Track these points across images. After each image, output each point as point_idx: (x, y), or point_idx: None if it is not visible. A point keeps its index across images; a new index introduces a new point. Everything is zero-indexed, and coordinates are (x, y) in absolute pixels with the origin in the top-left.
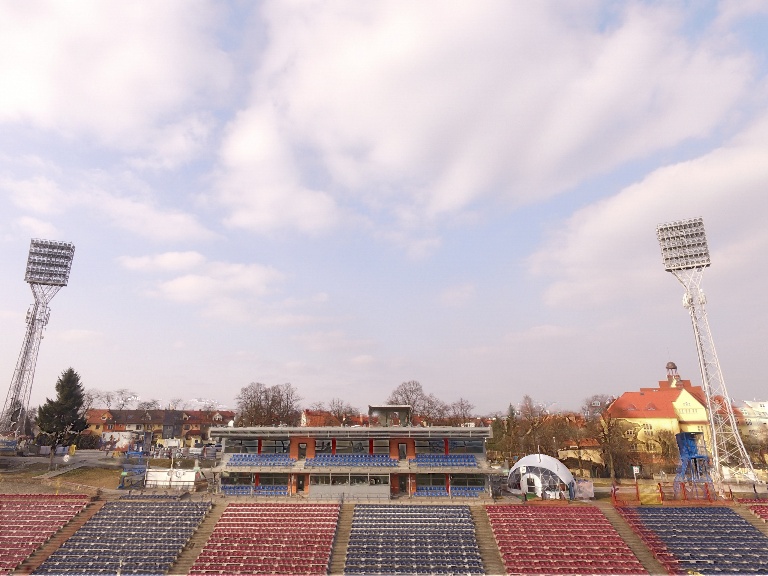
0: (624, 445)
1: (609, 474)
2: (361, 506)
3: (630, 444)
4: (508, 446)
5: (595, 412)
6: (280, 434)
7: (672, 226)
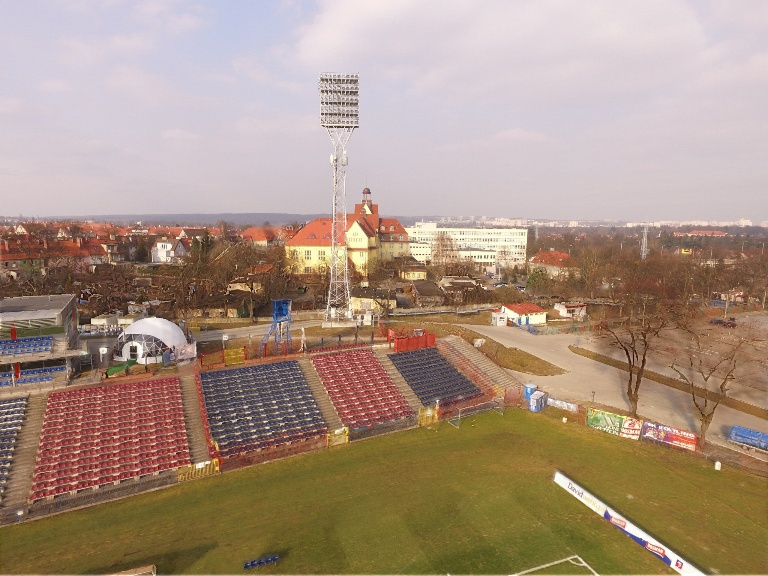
0: (277, 282)
1: (249, 314)
2: None
3: (283, 281)
4: (194, 272)
5: (287, 236)
6: None
7: (332, 78)
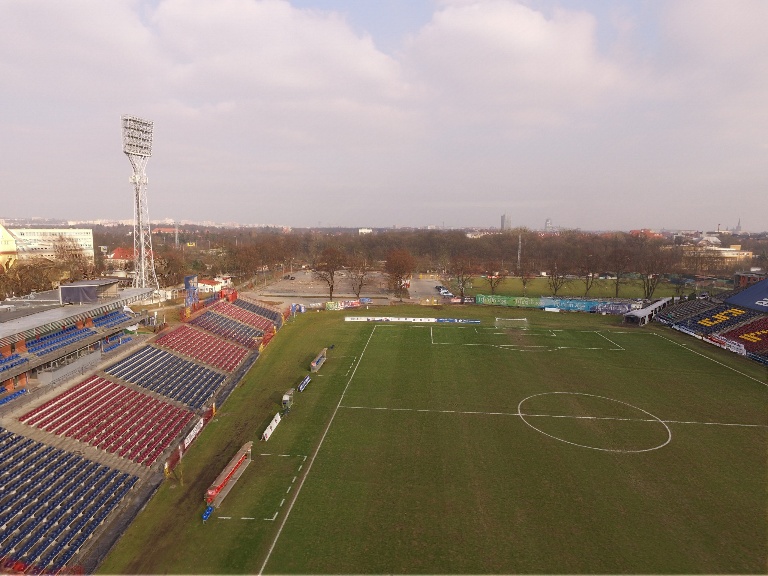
0: None
1: None
2: (108, 370)
3: None
4: None
5: None
6: (44, 329)
7: (137, 120)
